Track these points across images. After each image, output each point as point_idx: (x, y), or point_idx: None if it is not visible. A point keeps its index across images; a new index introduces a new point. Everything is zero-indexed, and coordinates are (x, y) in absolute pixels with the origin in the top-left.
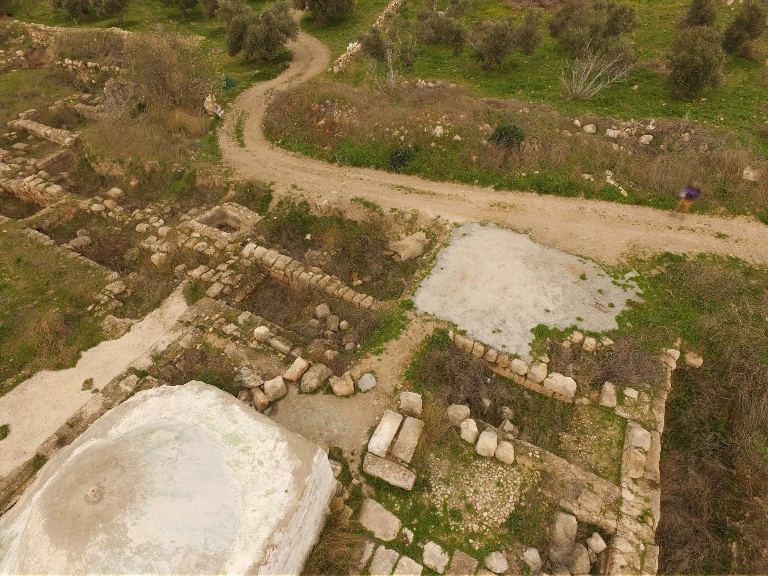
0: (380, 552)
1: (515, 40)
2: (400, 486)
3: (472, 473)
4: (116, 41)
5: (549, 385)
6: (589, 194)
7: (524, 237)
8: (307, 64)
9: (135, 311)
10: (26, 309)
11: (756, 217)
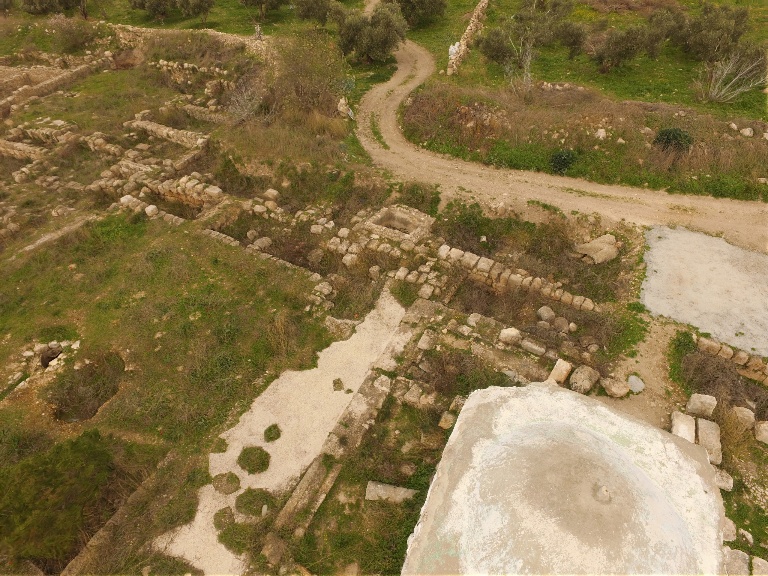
0: (728, 552)
1: None
2: (721, 487)
3: None
4: (212, 42)
5: None
6: (767, 198)
7: (721, 240)
8: (414, 66)
9: (352, 312)
10: (245, 310)
11: None
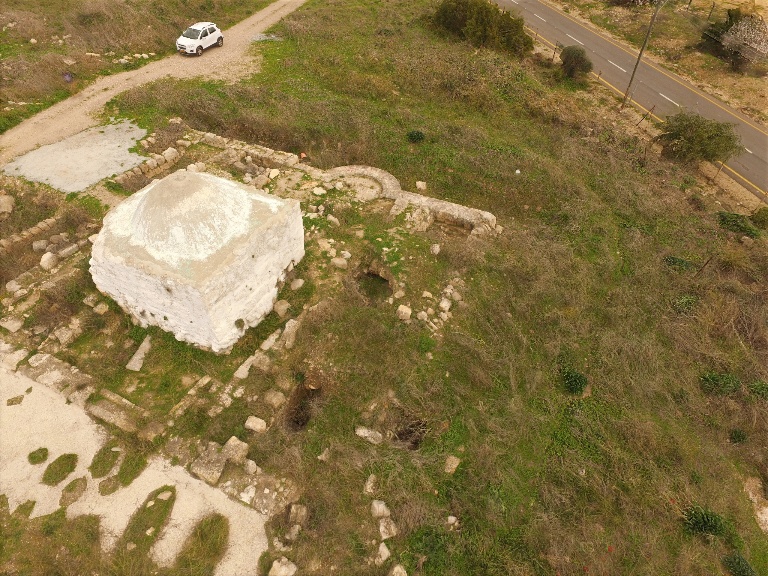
0: None
1: None
2: None
3: None
4: None
5: (168, 158)
6: (25, 115)
7: (45, 146)
8: None
9: None
10: None
11: (102, 75)
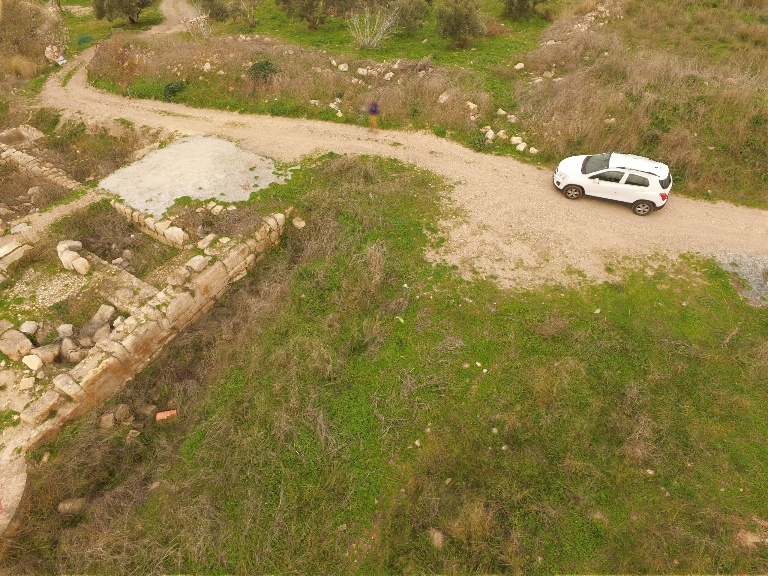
0: None
1: (327, 0)
2: None
3: (52, 279)
4: None
5: (167, 235)
6: (310, 115)
7: (230, 144)
8: (169, 27)
9: None
10: None
11: (432, 131)
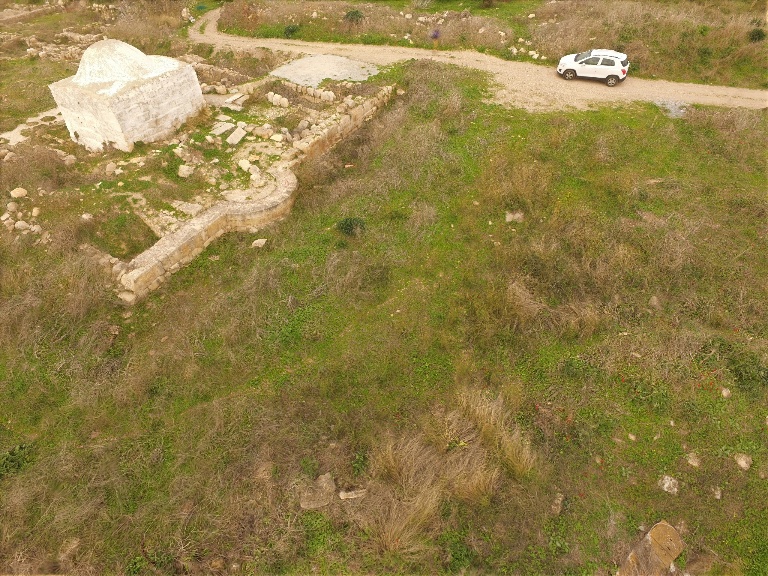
0: None
1: None
2: (235, 109)
3: (268, 109)
4: None
5: (323, 96)
6: (391, 43)
7: (343, 57)
8: None
9: None
10: None
11: (476, 49)
